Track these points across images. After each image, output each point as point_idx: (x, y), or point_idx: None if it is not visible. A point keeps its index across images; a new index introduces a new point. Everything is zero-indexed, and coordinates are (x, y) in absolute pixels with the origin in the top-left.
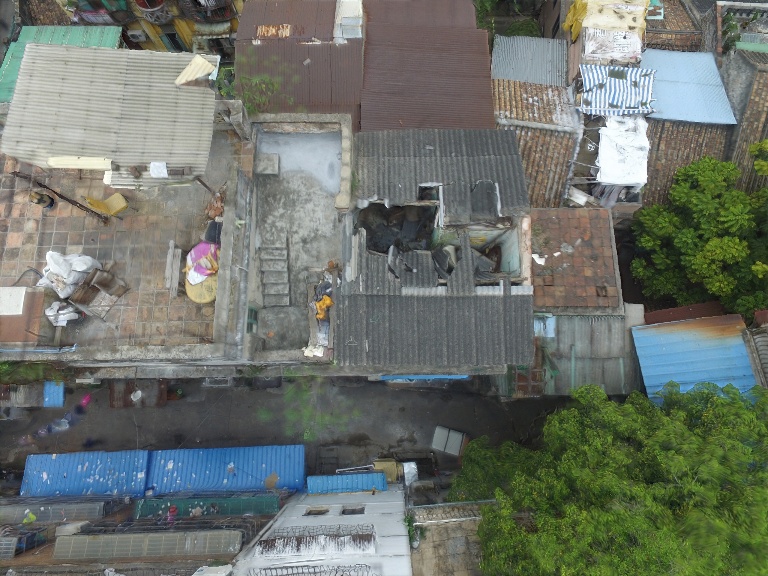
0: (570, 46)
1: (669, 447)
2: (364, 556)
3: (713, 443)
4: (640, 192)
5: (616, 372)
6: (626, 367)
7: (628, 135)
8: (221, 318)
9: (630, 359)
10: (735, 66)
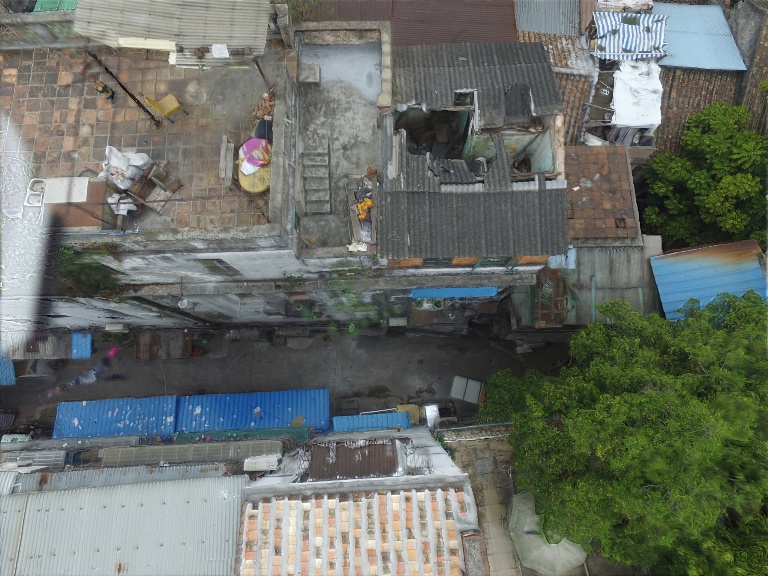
0: None
1: None
2: None
3: (738, 336)
4: (653, 136)
5: (635, 301)
6: (645, 296)
7: (642, 79)
8: (276, 200)
9: (649, 288)
10: (744, 14)
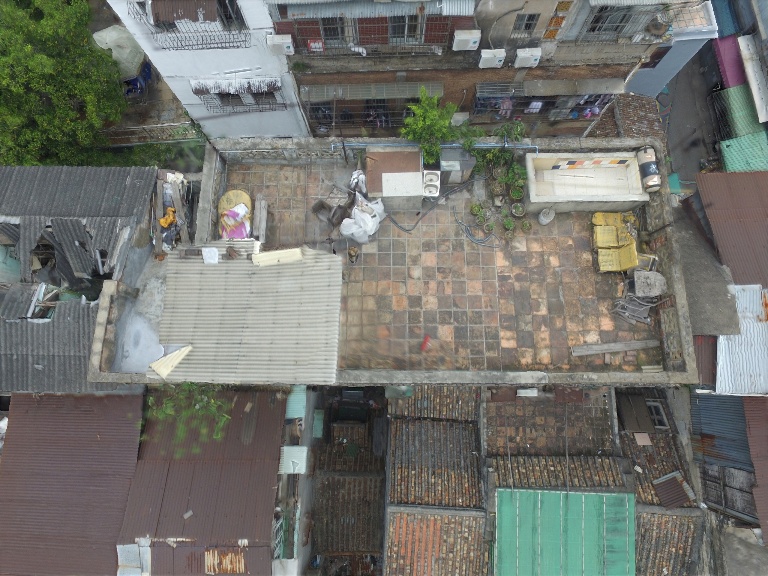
0: None
1: None
2: (196, 77)
3: None
4: None
5: None
6: None
7: None
8: (208, 168)
9: None
10: None
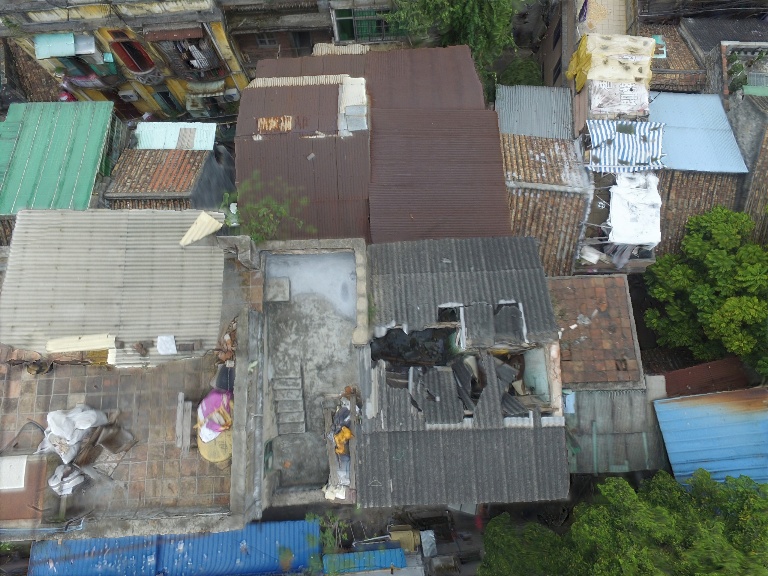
0: (574, 96)
1: (708, 562)
2: None
3: (755, 561)
4: (653, 248)
5: (639, 448)
6: (649, 442)
7: (639, 192)
8: (238, 486)
9: (653, 433)
10: (744, 112)
